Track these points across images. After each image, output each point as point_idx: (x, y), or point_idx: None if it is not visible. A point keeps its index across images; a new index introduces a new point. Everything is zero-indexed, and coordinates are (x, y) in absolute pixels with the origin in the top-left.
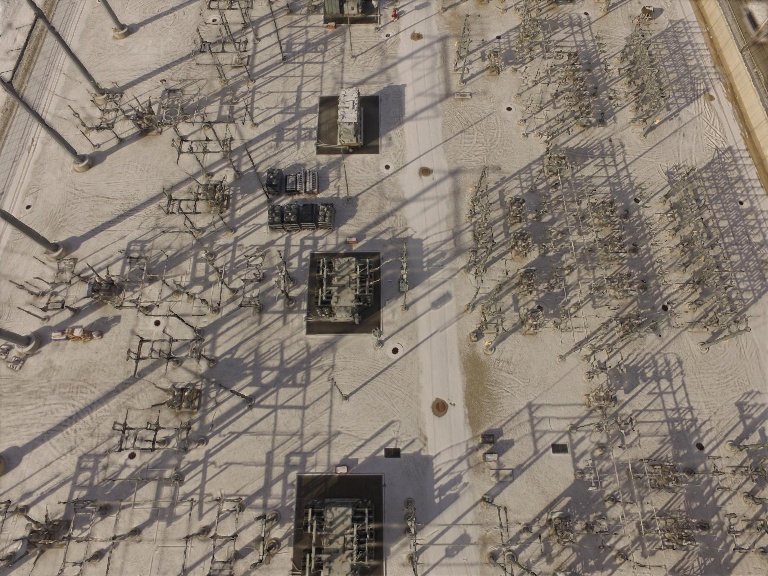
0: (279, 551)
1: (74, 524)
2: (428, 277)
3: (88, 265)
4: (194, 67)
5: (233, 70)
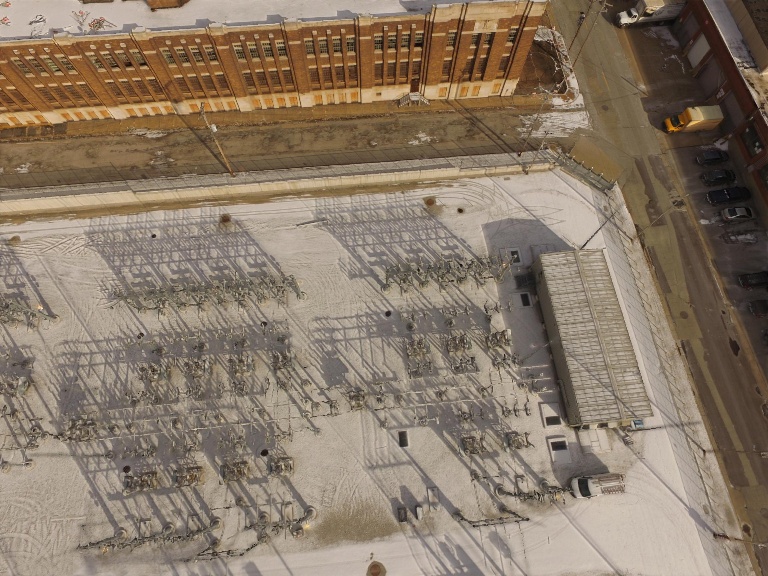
0: None
1: None
2: None
3: None
4: None
5: None
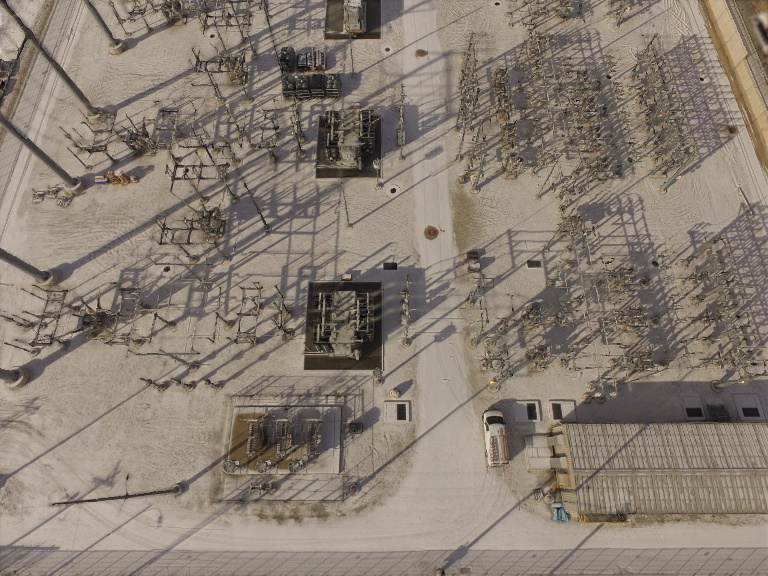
0: (293, 338)
1: (119, 319)
2: (423, 135)
3: (127, 116)
4: None
5: None
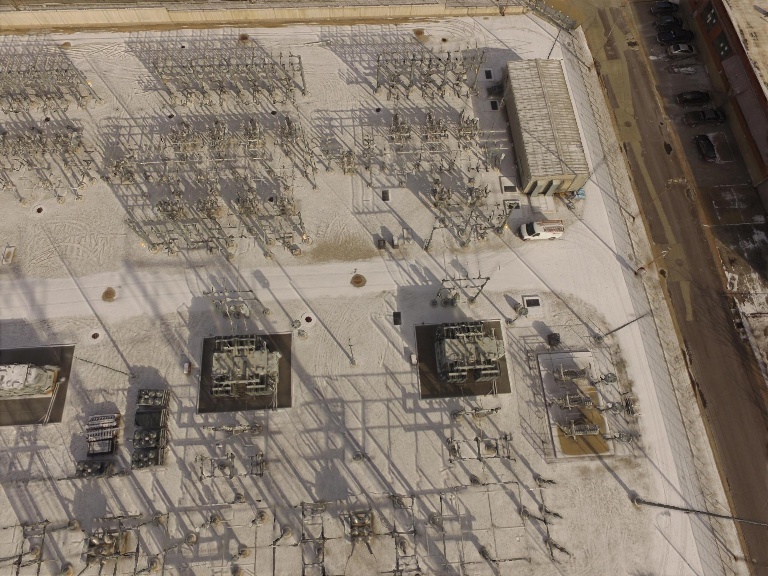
0: None
1: None
2: None
3: None
4: None
5: None
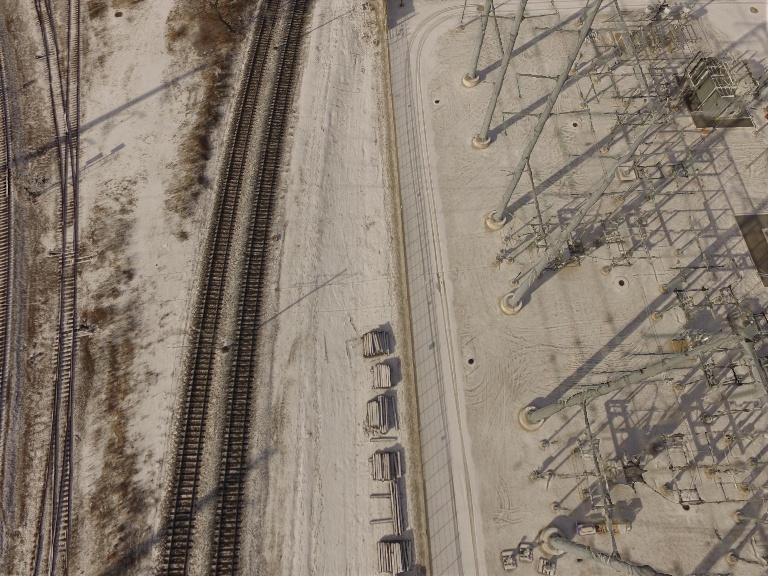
0: None
1: None
2: None
3: (624, 449)
4: (579, 182)
5: (623, 185)
